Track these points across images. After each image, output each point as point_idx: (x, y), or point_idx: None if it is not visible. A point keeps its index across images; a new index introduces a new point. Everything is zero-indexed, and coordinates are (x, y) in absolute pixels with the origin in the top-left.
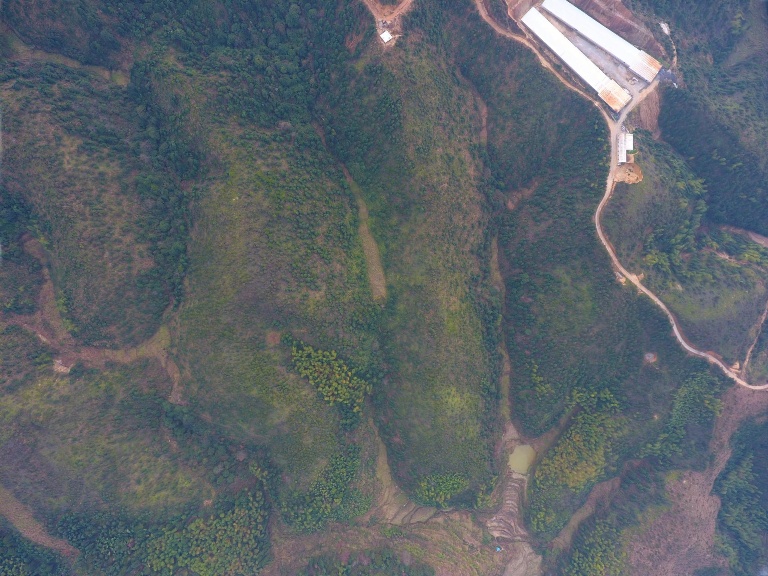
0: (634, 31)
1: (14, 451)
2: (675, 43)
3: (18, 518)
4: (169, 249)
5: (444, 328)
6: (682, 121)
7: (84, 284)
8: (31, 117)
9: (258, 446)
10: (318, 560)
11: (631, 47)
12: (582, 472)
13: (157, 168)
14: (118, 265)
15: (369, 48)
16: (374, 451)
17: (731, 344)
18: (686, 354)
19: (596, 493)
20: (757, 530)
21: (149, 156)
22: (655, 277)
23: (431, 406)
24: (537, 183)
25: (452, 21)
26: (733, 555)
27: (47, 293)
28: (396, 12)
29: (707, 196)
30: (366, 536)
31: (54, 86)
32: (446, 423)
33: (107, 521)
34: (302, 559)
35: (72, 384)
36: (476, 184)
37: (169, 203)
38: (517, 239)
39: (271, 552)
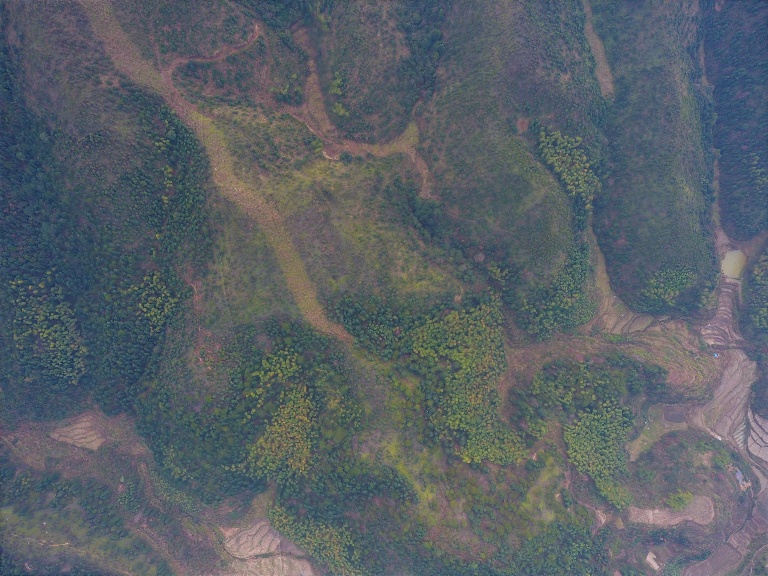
0: None
1: (312, 218)
2: None
3: (304, 297)
4: (420, 41)
5: (680, 112)
6: None
7: (360, 63)
8: None
9: (499, 244)
10: (554, 362)
11: None
12: None
13: None
14: (386, 47)
15: None
16: (594, 260)
17: None
18: None
19: None
20: None
21: None
22: None
23: (670, 190)
24: None
25: None
26: None
27: (311, 86)
28: None
29: None
30: (592, 343)
31: None
32: (683, 208)
33: (377, 307)
34: (535, 365)
35: (347, 166)
36: None
37: None
38: (730, 36)
39: (505, 359)
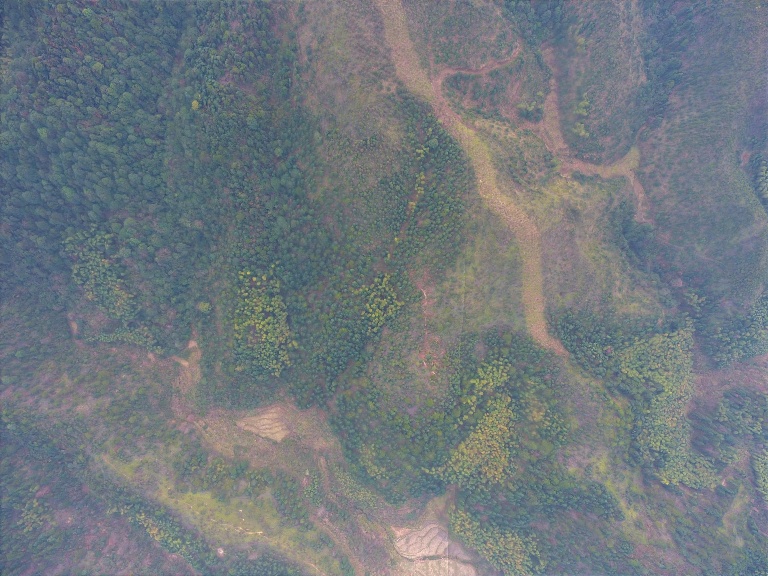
0: None
1: (560, 235)
2: None
3: (533, 311)
4: None
5: None
6: None
7: (610, 86)
8: None
9: (700, 271)
10: (735, 391)
11: None
12: None
13: None
14: (633, 72)
15: None
16: None
17: None
18: None
19: None
20: None
21: None
22: None
23: None
24: None
25: None
26: None
27: (549, 104)
28: None
29: None
30: (767, 374)
31: None
32: None
33: (593, 325)
34: (715, 391)
35: (583, 186)
36: None
37: None
38: None
39: None
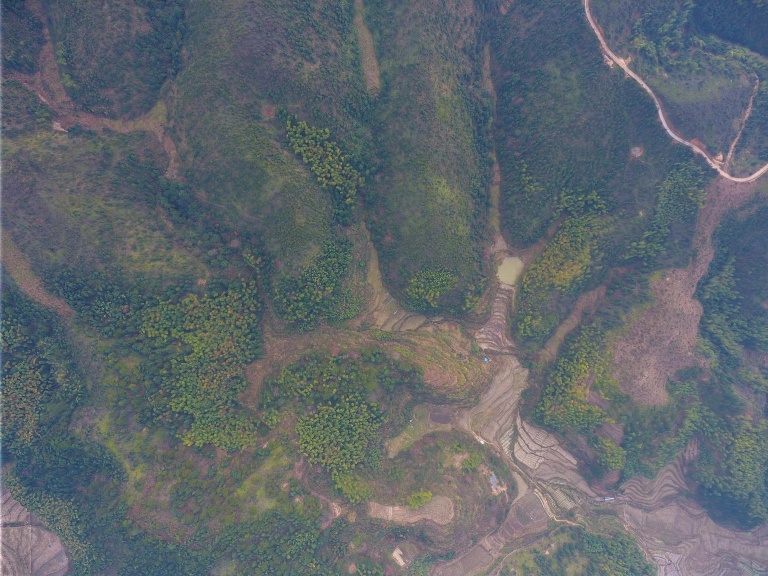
0: None
1: (13, 187)
2: None
3: (16, 267)
4: (167, 19)
5: (435, 112)
6: None
7: (83, 34)
8: None
9: (252, 231)
10: (309, 354)
11: None
12: (568, 270)
13: None
14: (117, 20)
15: None
16: (366, 255)
17: (715, 132)
18: (671, 141)
19: (582, 304)
20: (738, 340)
21: None
22: (642, 63)
23: (422, 190)
24: None
25: None
26: (714, 357)
27: (47, 55)
28: None
29: None
30: (357, 338)
31: None
32: (436, 209)
33: (103, 284)
34: (294, 355)
35: (70, 139)
36: None
37: None
38: (509, 40)
39: (263, 348)
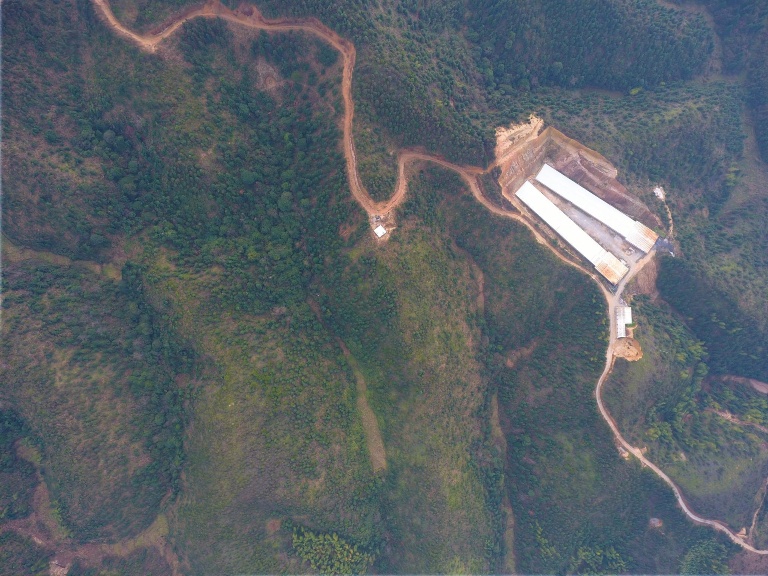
0: (629, 204)
1: None
2: (670, 208)
3: None
4: (165, 441)
5: (446, 504)
6: (680, 286)
7: (79, 494)
8: (21, 338)
9: None
10: None
11: (627, 218)
12: None
13: (151, 363)
14: (113, 470)
15: (363, 241)
16: None
17: (737, 513)
18: (692, 524)
19: None
20: None
21: (142, 352)
22: (658, 449)
23: None
24: (536, 343)
25: (446, 199)
26: None
27: (41, 494)
28: (389, 205)
29: (707, 357)
30: None
31: (44, 296)
32: None
33: None
34: None
35: None
36: (474, 355)
37: (164, 397)
38: (517, 400)
39: None
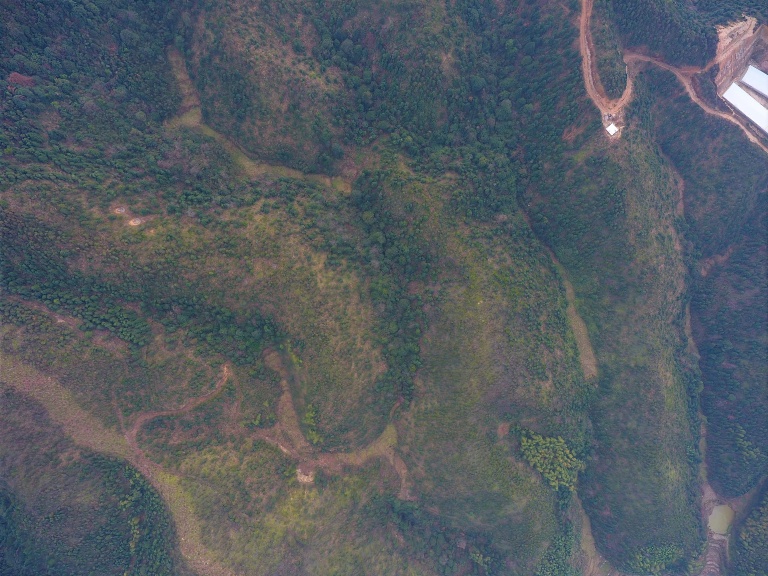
0: None
1: (284, 572)
2: None
3: None
4: (397, 350)
5: (664, 405)
6: None
7: (333, 397)
8: (286, 240)
9: (481, 533)
10: None
11: None
12: None
13: (384, 272)
14: (361, 374)
15: (593, 141)
16: (579, 524)
17: None
18: None
19: None
20: None
21: (378, 261)
22: None
23: (655, 483)
24: (732, 250)
25: (657, 103)
26: None
27: (284, 404)
28: (619, 104)
29: None
30: None
31: (294, 204)
32: (668, 498)
33: None
34: None
35: (321, 495)
36: (682, 259)
37: (398, 305)
38: (716, 306)
39: None
